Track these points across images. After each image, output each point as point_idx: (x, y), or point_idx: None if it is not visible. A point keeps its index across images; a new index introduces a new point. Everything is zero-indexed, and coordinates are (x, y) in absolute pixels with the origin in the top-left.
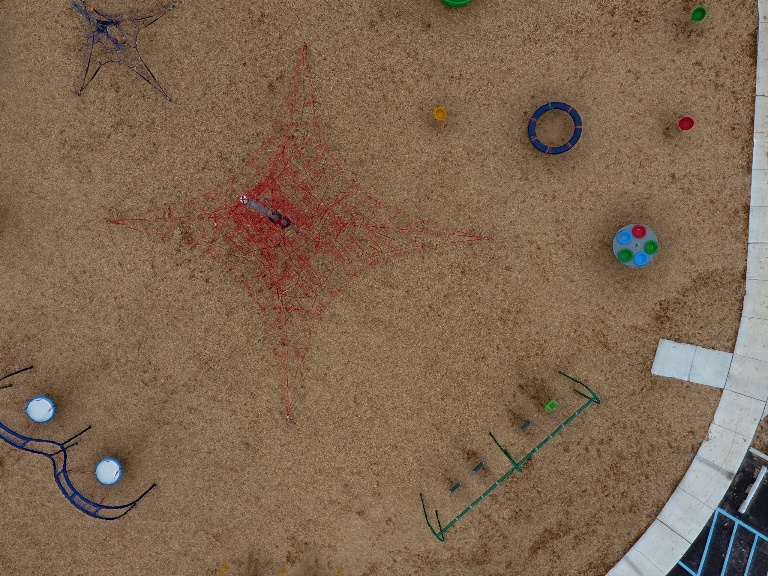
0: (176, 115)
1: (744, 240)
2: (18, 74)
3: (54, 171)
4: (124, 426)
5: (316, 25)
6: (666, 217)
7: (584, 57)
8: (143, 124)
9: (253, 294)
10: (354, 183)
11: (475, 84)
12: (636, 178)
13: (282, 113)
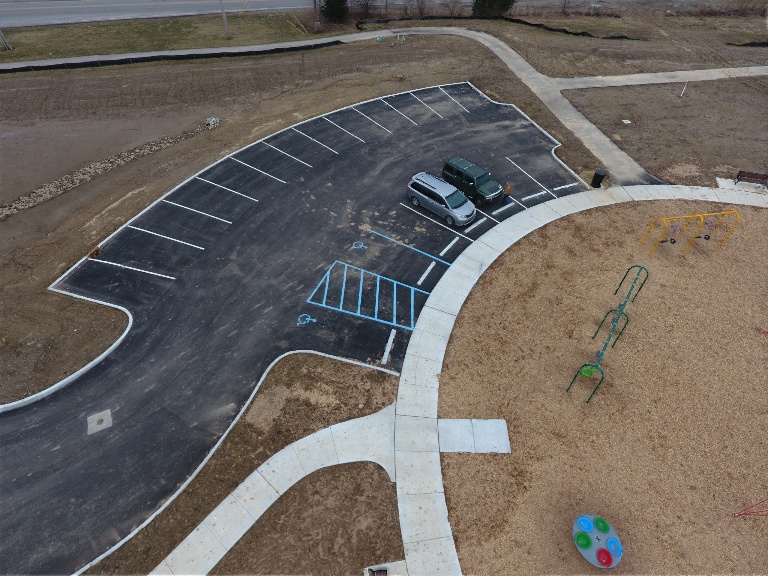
0: None
1: None
2: None
3: None
4: None
5: None
6: None
7: None
8: None
9: None
10: None
11: None
12: None
13: None
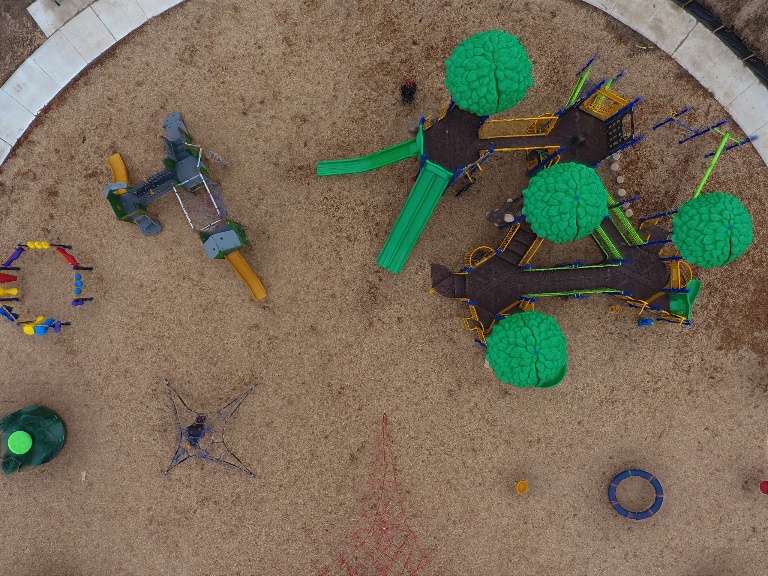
0: (260, 490)
1: None
2: (105, 454)
3: (142, 547)
4: None
5: (395, 396)
6: (748, 571)
7: (661, 416)
8: (228, 499)
9: None
10: (436, 548)
11: (554, 447)
12: (717, 534)
13: (364, 483)
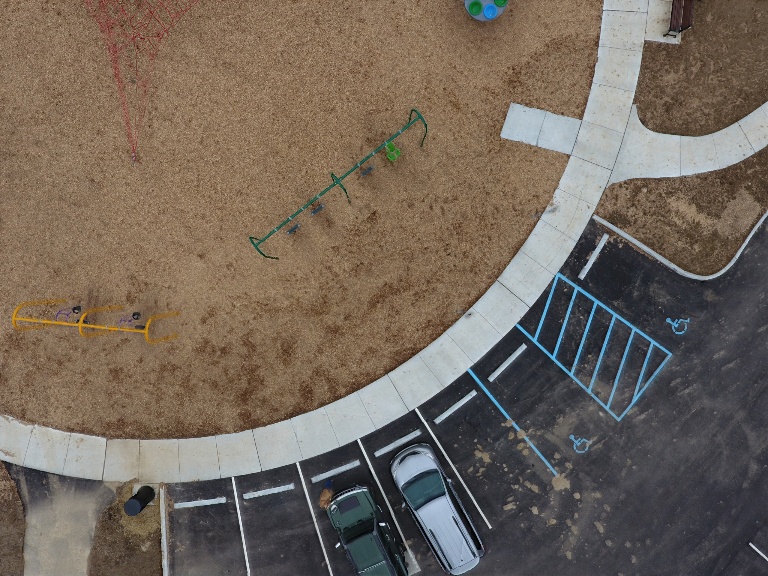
0: None
1: (599, 7)
2: None
3: None
4: None
5: None
6: None
7: None
8: None
9: (105, 30)
10: None
11: None
12: None
13: None
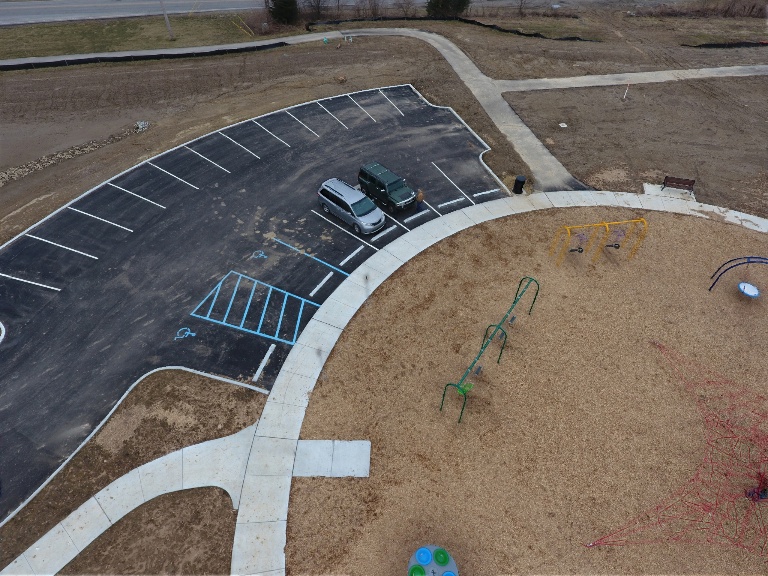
0: None
1: None
2: None
3: None
4: (761, 319)
5: None
6: None
7: None
8: None
9: (760, 432)
10: None
11: None
12: None
13: None
